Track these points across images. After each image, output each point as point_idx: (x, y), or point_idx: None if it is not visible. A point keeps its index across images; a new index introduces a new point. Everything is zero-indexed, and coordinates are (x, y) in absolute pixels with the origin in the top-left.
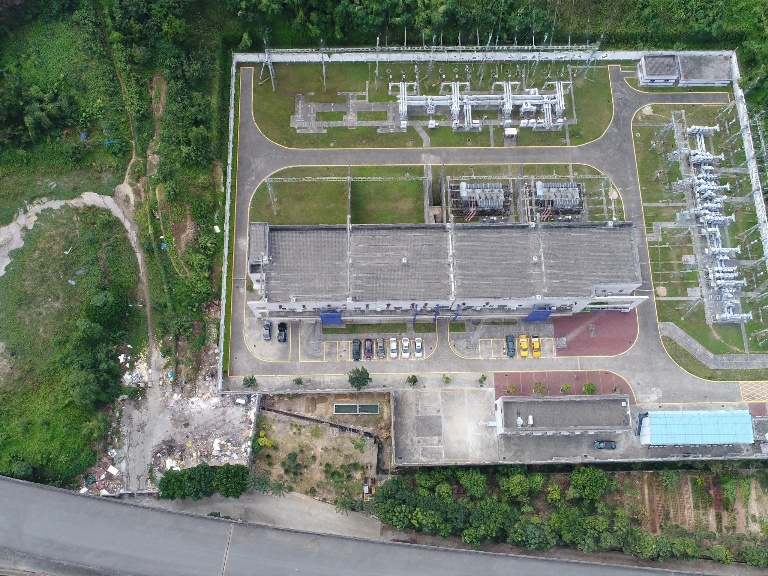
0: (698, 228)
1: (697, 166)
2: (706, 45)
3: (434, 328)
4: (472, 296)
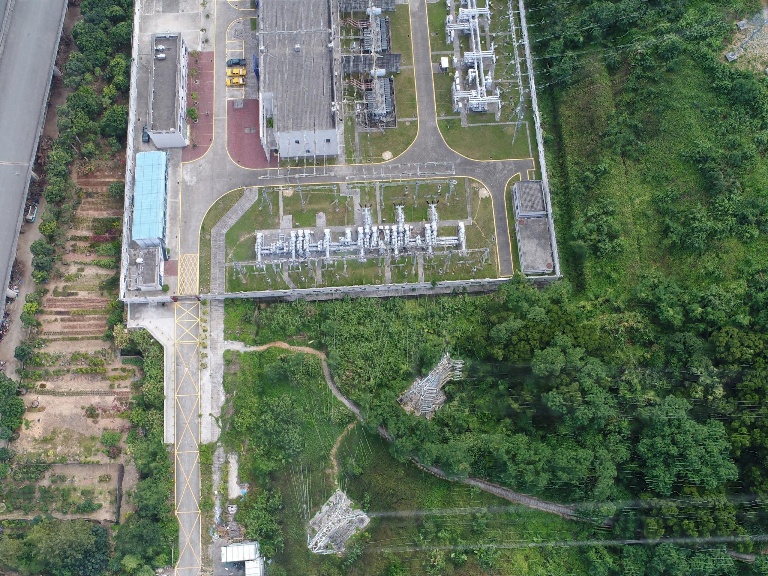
0: (355, 230)
1: (423, 235)
2: (571, 258)
3: (255, 7)
4: (265, 1)
